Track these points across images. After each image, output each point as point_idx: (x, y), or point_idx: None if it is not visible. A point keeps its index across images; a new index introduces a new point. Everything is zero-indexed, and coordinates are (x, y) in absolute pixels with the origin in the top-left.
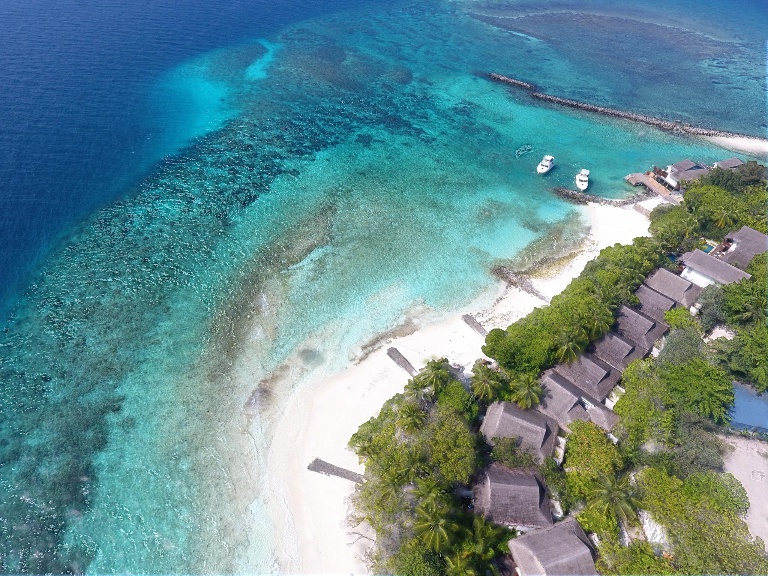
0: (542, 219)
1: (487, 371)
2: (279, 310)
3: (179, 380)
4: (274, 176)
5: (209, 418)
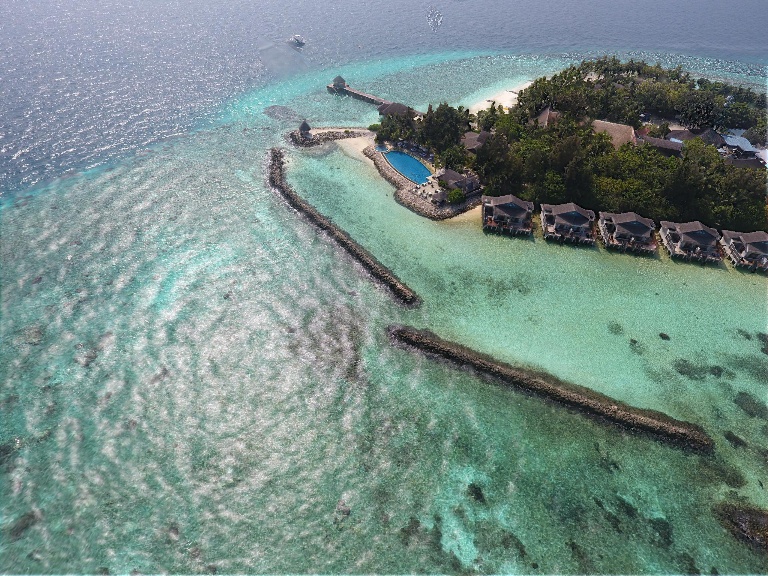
0: None
1: None
2: None
3: None
4: (762, 76)
5: None
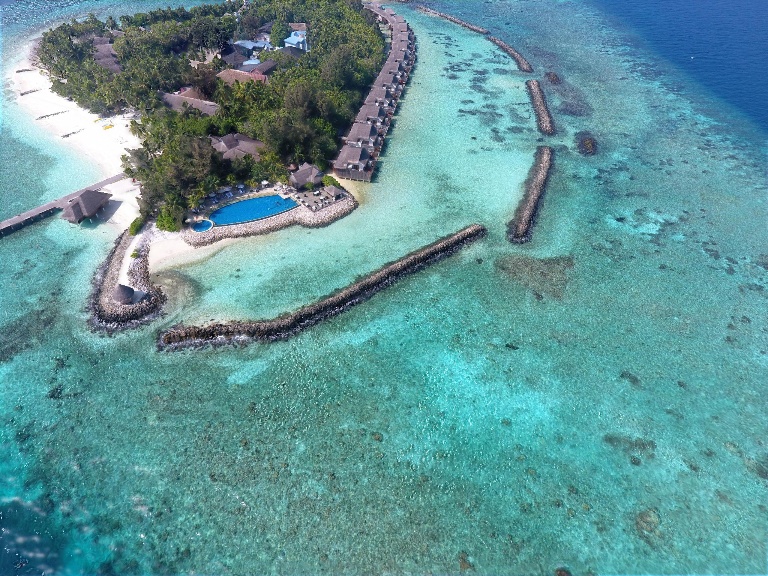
0: None
1: (109, 17)
2: None
3: (6, 37)
4: (85, 0)
5: (14, 42)
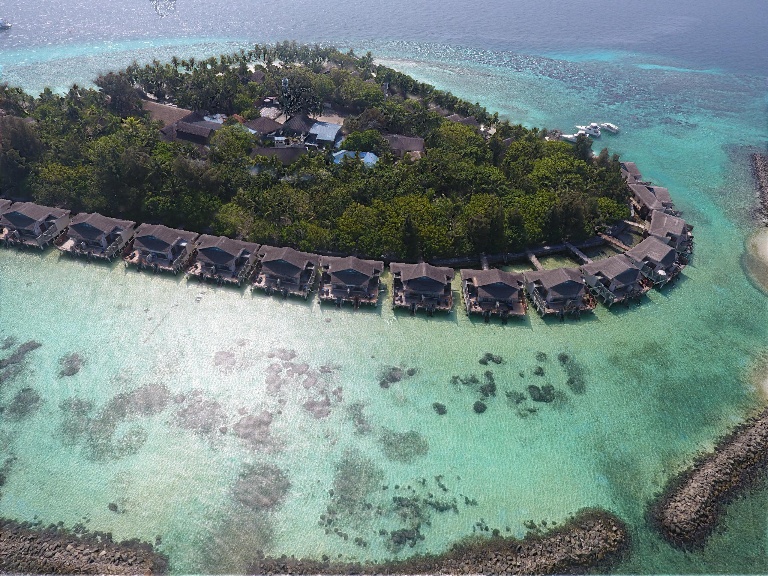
0: (515, 121)
1: (368, 59)
2: (410, 65)
3: None
4: (511, 67)
5: None
